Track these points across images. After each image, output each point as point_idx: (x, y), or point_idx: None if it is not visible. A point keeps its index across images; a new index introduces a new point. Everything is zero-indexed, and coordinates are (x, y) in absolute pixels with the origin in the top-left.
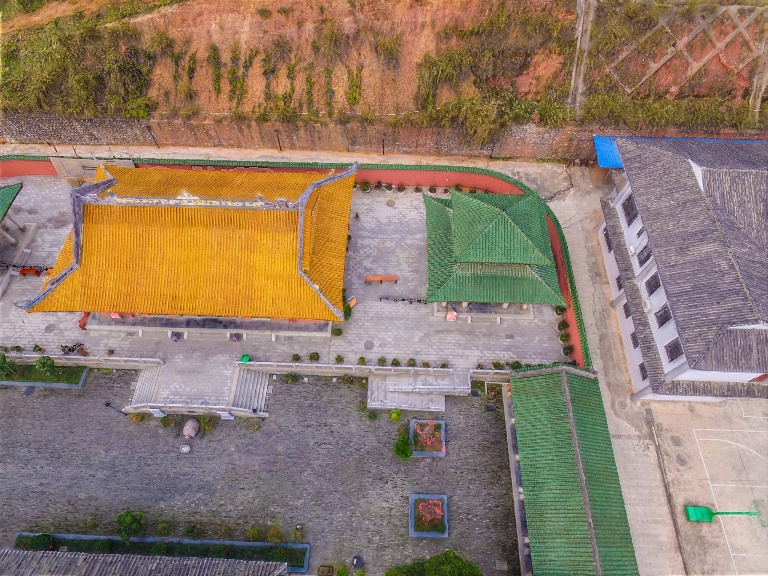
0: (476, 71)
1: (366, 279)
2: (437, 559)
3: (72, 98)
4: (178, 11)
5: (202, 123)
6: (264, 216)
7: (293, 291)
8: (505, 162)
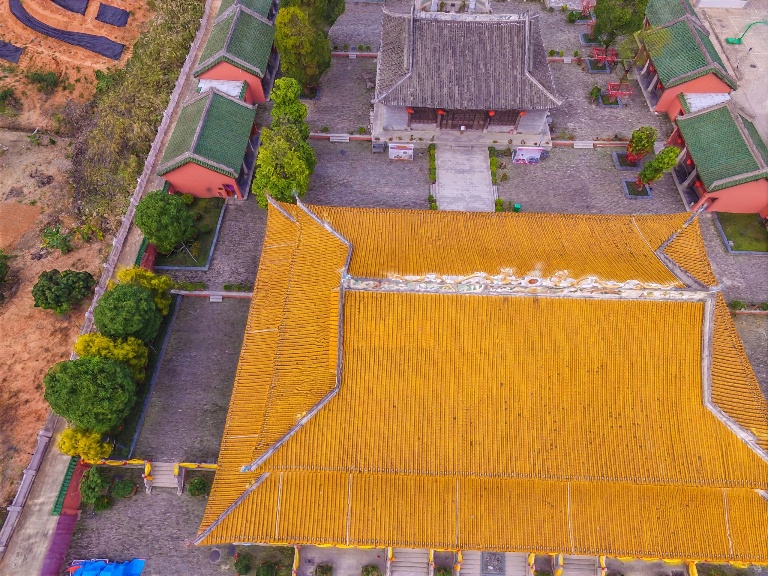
0: None
1: None
2: None
3: None
4: None
5: None
6: None
7: None
8: None
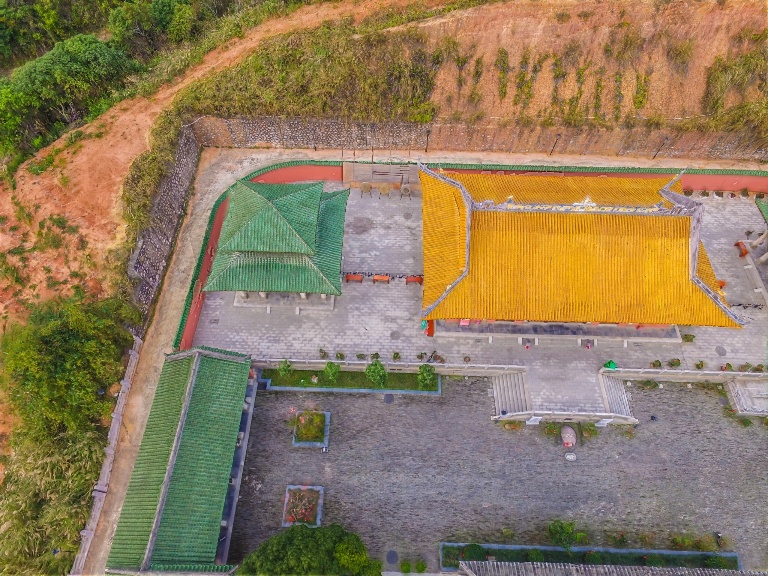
0: (764, 75)
1: None
2: None
3: (358, 103)
4: (474, 15)
5: (486, 127)
6: (652, 222)
7: (685, 297)
8: None
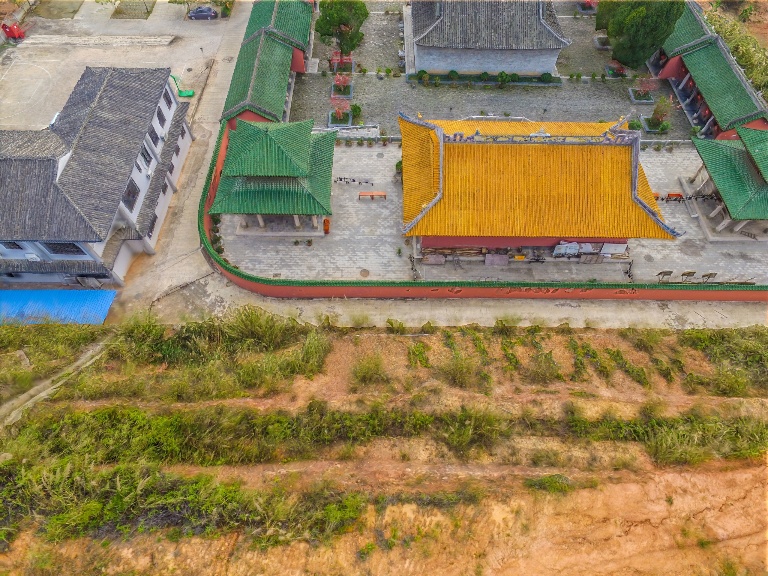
0: None
1: (386, 195)
2: None
3: None
4: (729, 400)
5: None
6: None
7: None
8: None
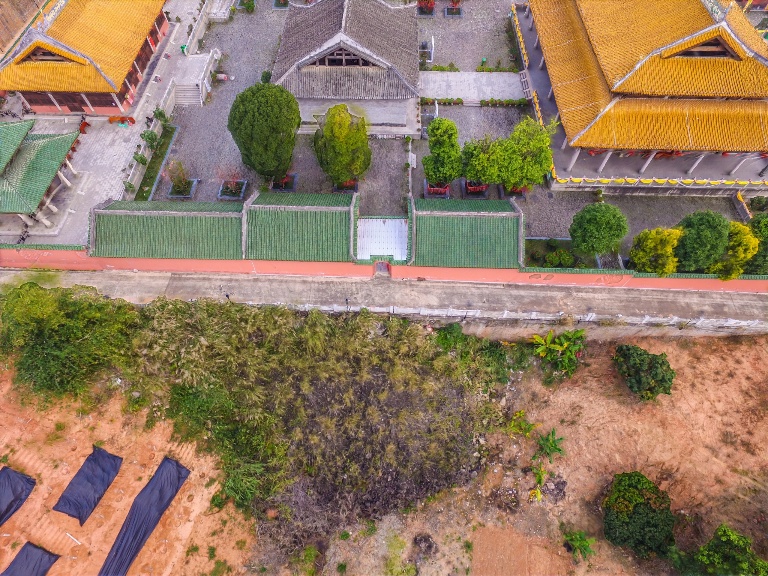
0: None
1: None
2: None
3: None
4: None
5: None
6: None
7: None
8: None
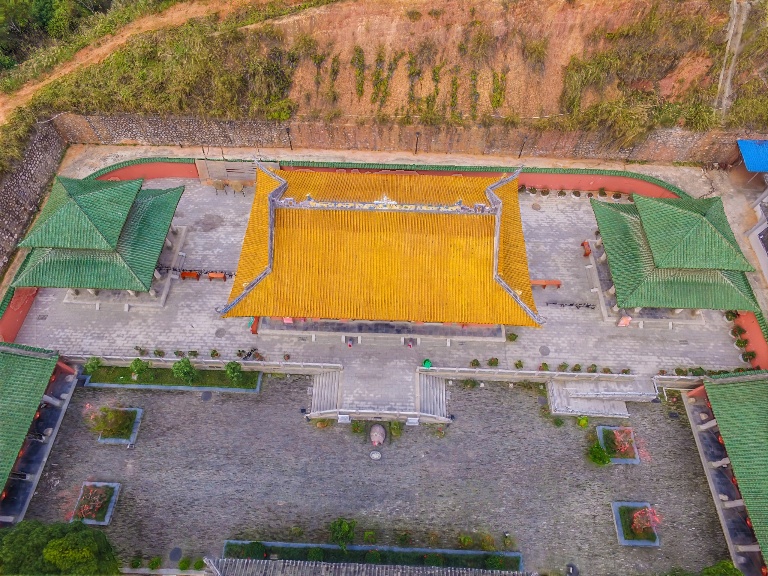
0: (621, 74)
1: None
2: (717, 570)
3: (214, 100)
4: (326, 13)
5: (344, 125)
6: (457, 221)
7: (488, 296)
8: (642, 165)
